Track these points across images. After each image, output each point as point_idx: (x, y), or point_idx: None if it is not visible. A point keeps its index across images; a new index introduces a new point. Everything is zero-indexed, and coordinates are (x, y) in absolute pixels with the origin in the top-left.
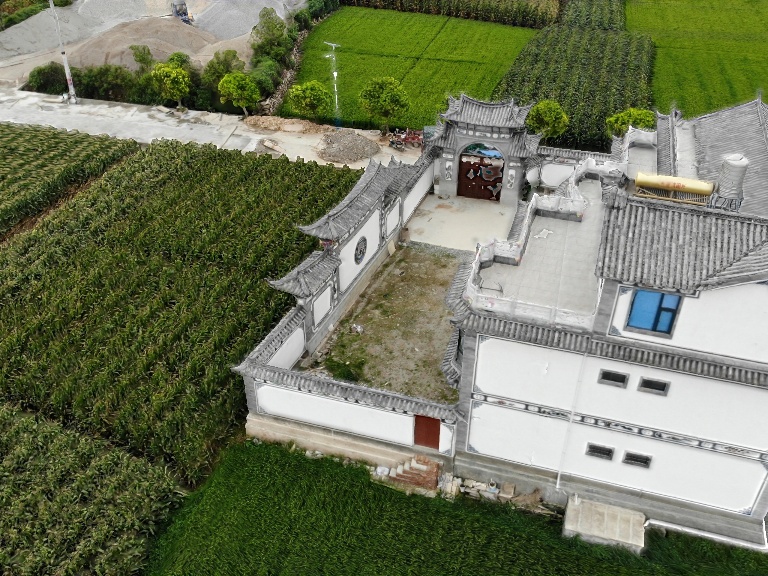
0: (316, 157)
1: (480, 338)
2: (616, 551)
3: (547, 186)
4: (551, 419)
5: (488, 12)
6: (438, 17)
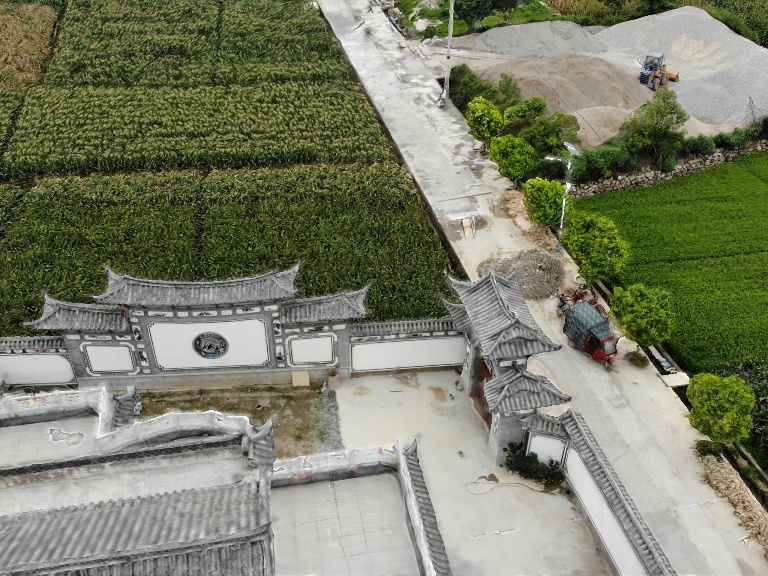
0: (478, 261)
1: None
2: None
3: (568, 479)
4: None
5: None
6: None
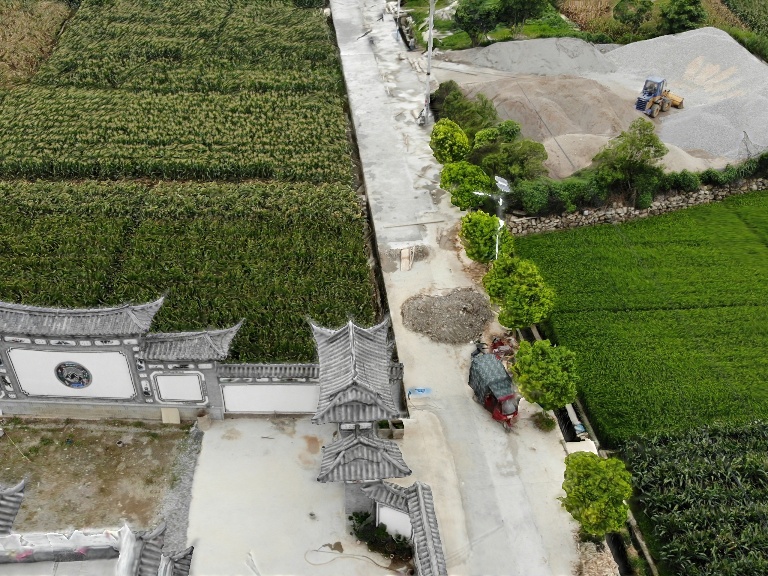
0: (406, 297)
1: None
2: None
3: (415, 557)
4: None
5: None
6: None
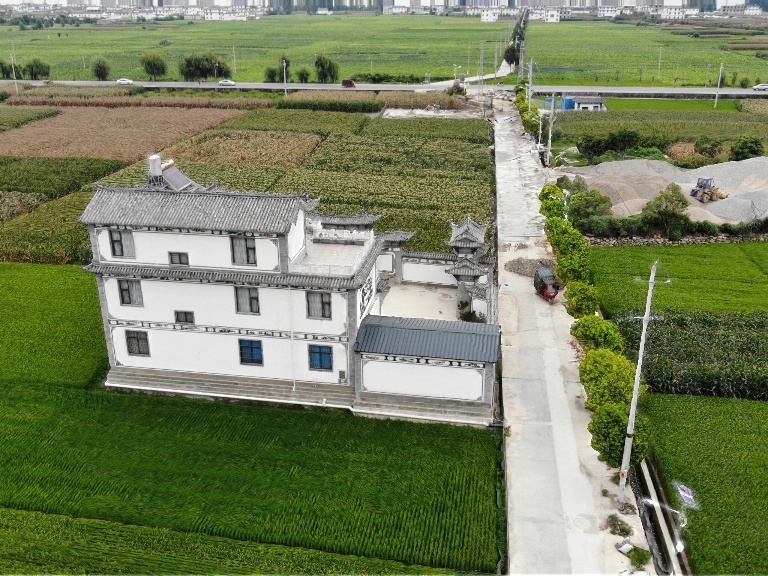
0: (509, 260)
1: None
2: None
3: None
4: None
5: None
6: None
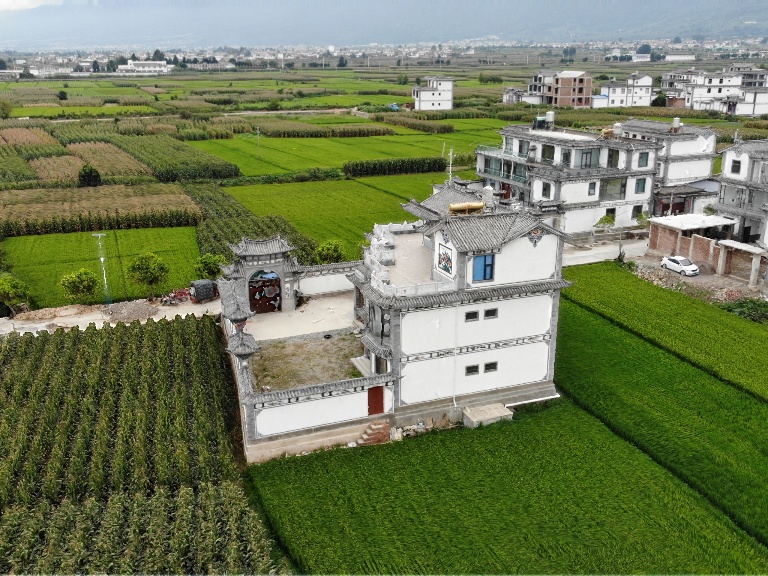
0: (111, 324)
1: (401, 316)
2: (502, 423)
3: (305, 295)
4: (445, 358)
5: (146, 221)
6: (104, 231)
